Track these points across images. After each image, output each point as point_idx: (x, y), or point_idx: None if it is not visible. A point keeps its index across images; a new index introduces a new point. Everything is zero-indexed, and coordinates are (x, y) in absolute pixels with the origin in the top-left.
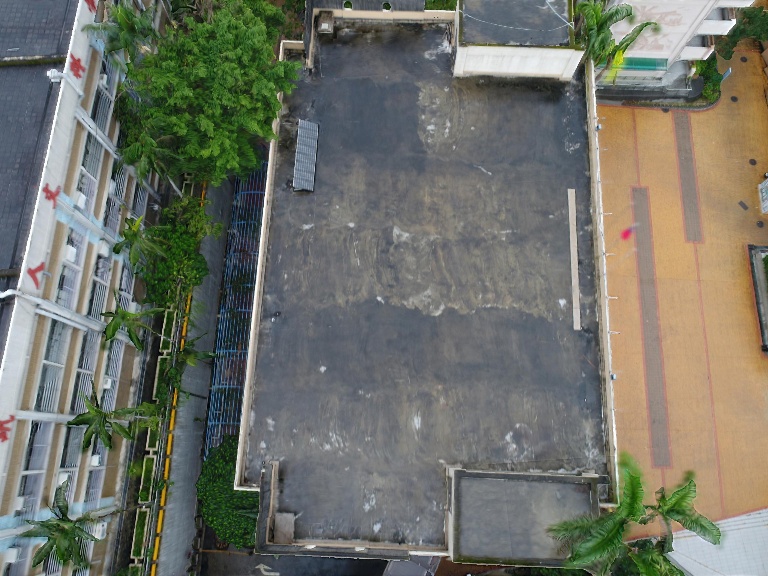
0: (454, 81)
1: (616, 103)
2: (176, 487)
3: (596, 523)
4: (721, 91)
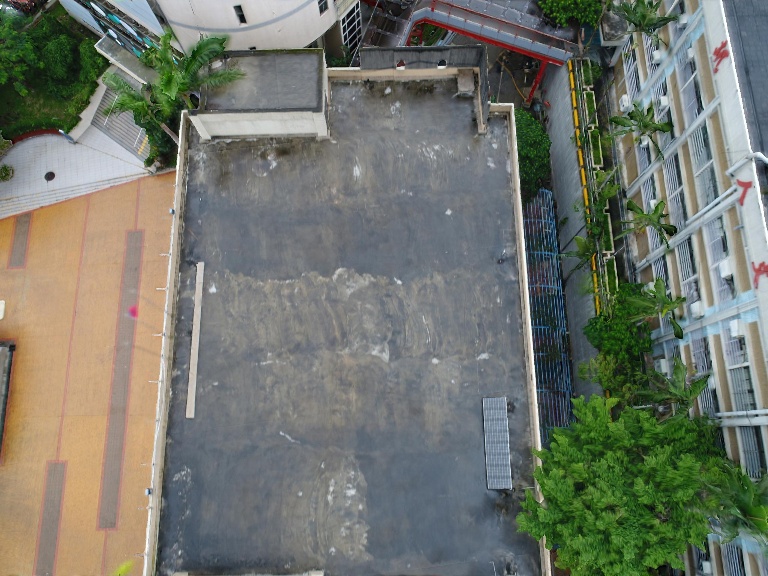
0: (323, 564)
1: None
2: (570, 154)
3: (204, 81)
4: None
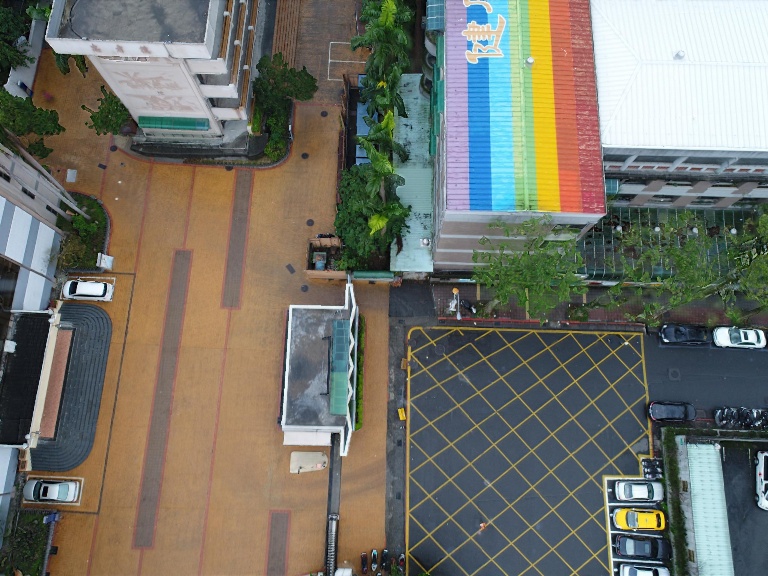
0: None
1: (177, 161)
2: None
3: None
4: (293, 147)
